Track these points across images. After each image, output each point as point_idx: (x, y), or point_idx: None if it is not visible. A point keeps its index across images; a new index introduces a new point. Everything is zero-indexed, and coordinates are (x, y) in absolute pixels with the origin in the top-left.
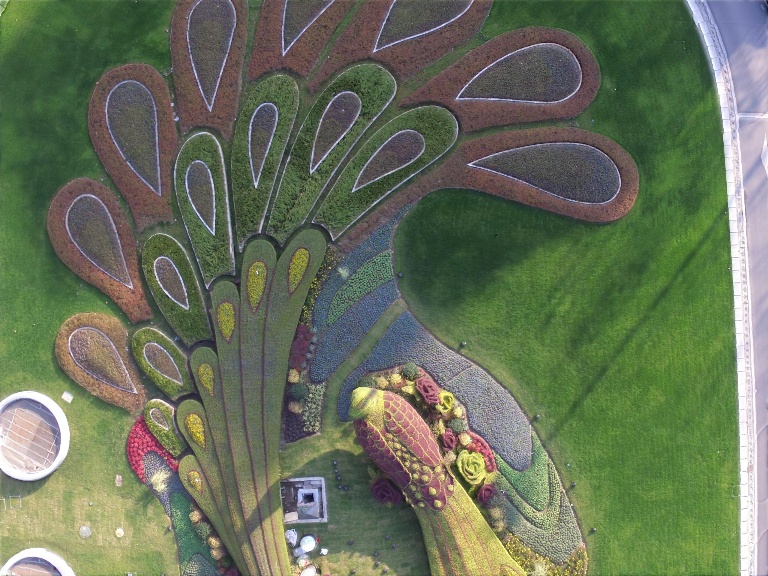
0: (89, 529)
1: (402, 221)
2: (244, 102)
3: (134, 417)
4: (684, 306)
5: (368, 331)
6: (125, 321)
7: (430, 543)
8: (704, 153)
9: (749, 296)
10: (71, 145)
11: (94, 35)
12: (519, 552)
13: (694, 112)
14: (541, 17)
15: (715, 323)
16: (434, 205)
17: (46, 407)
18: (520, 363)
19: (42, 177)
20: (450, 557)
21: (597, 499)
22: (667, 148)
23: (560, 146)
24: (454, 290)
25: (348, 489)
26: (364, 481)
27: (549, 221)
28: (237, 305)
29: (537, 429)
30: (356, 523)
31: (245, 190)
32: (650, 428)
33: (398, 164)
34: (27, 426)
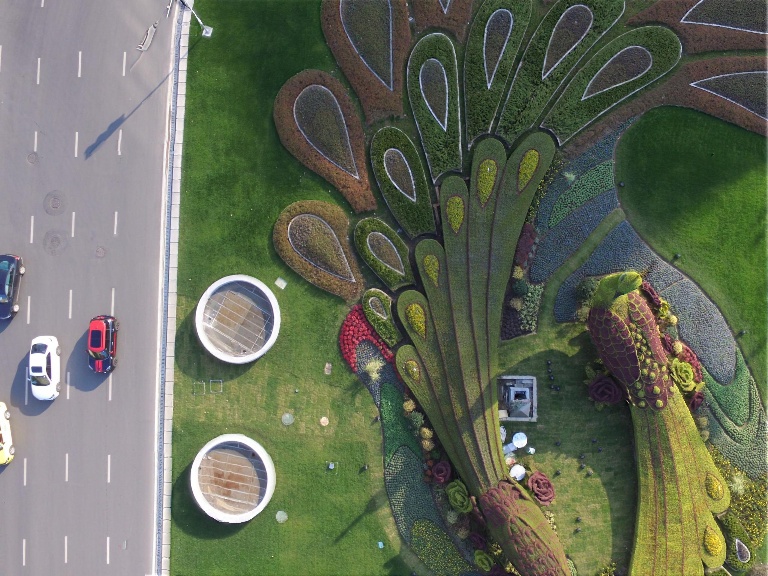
0: (292, 416)
1: (625, 133)
2: (478, 7)
3: (349, 306)
4: None
5: (587, 236)
6: (347, 210)
7: (643, 446)
8: None
9: None
10: (302, 37)
11: None
12: (720, 464)
13: None
14: None
15: None
16: (656, 120)
17: (261, 290)
18: (729, 280)
19: (270, 66)
20: (662, 460)
21: None
22: None
23: None
24: (671, 204)
25: (560, 390)
26: (576, 383)
27: (762, 145)
28: (466, 200)
29: (741, 346)
30: (565, 424)
31: (478, 90)
32: None
33: (626, 77)
34: (237, 309)
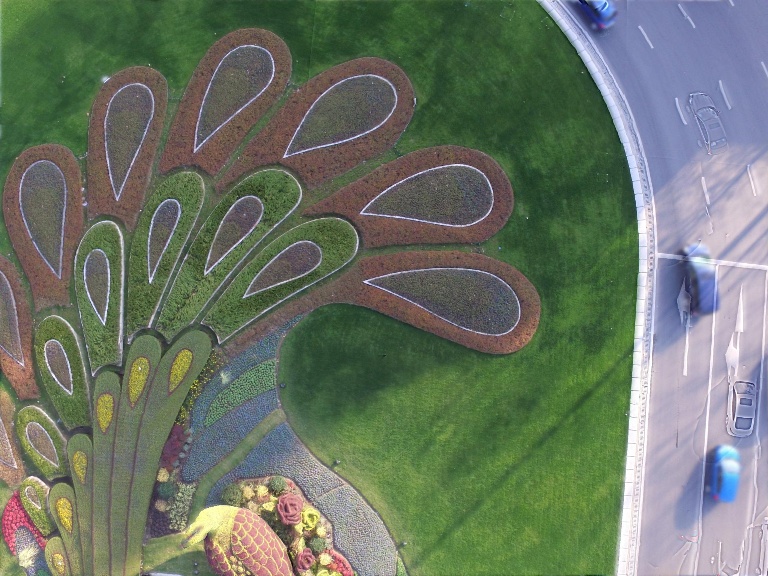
0: None
1: (291, 331)
2: (151, 195)
3: (12, 490)
4: (572, 449)
5: (244, 437)
6: (14, 396)
7: None
8: (614, 292)
9: (645, 444)
10: None
11: (20, 110)
12: None
13: (609, 249)
14: (459, 136)
15: (604, 470)
16: (325, 319)
17: None
18: (393, 488)
19: None
20: None
21: None
22: (575, 284)
23: (461, 272)
24: (335, 407)
25: None
26: None
27: (440, 347)
28: (117, 398)
29: (404, 556)
30: None
31: (139, 284)
32: (521, 569)
33: (292, 275)
34: None
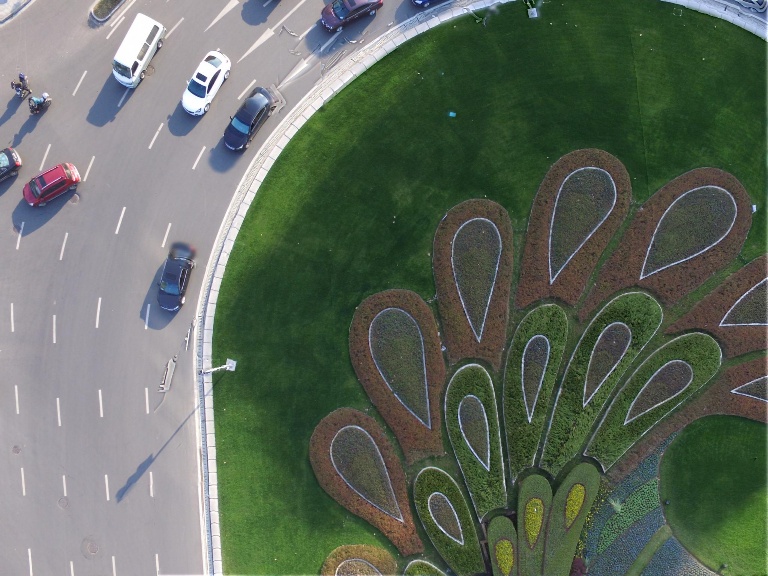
0: None
1: (668, 449)
2: (512, 332)
3: None
4: None
5: (636, 558)
6: (394, 553)
7: None
8: None
9: None
10: (331, 373)
11: (350, 256)
12: None
13: None
14: None
15: None
16: (698, 432)
17: None
18: None
19: (301, 405)
20: None
21: None
22: None
23: None
24: (716, 514)
25: None
26: None
27: None
28: (515, 542)
29: None
30: None
31: (519, 425)
32: None
33: (668, 395)
34: None
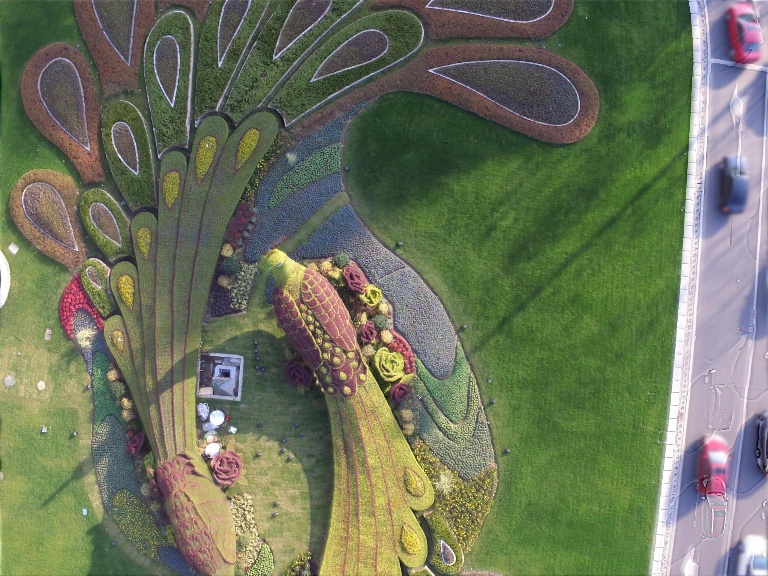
0: (14, 378)
1: (356, 117)
2: None
3: (72, 274)
4: (630, 240)
5: (307, 219)
6: (78, 181)
7: (337, 433)
8: (670, 92)
9: (700, 241)
10: (55, 11)
11: None
12: (427, 460)
13: (664, 51)
14: None
15: (660, 262)
16: (389, 105)
17: None
18: (454, 271)
19: (24, 39)
20: (354, 450)
21: (515, 421)
22: (632, 82)
23: (522, 64)
24: (398, 190)
25: (265, 371)
26: (282, 365)
27: (502, 136)
28: (183, 175)
29: (463, 340)
30: (268, 406)
31: (209, 68)
32: (579, 357)
33: (359, 60)
34: None
